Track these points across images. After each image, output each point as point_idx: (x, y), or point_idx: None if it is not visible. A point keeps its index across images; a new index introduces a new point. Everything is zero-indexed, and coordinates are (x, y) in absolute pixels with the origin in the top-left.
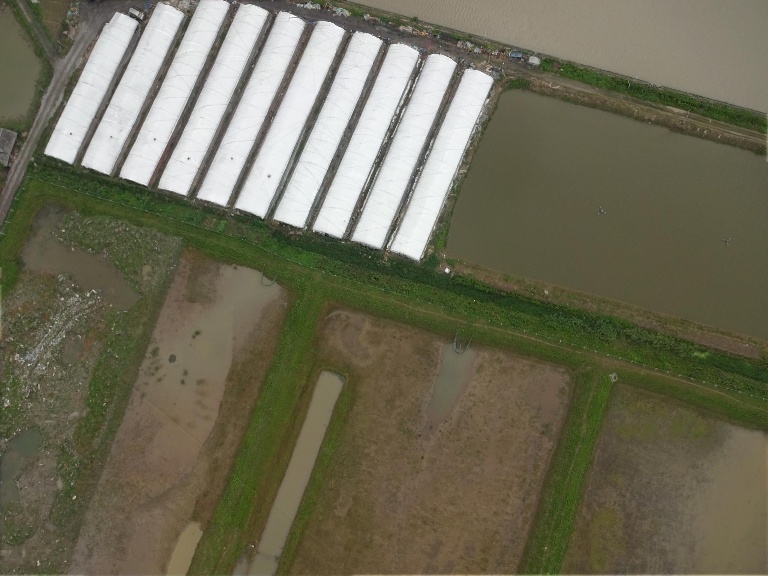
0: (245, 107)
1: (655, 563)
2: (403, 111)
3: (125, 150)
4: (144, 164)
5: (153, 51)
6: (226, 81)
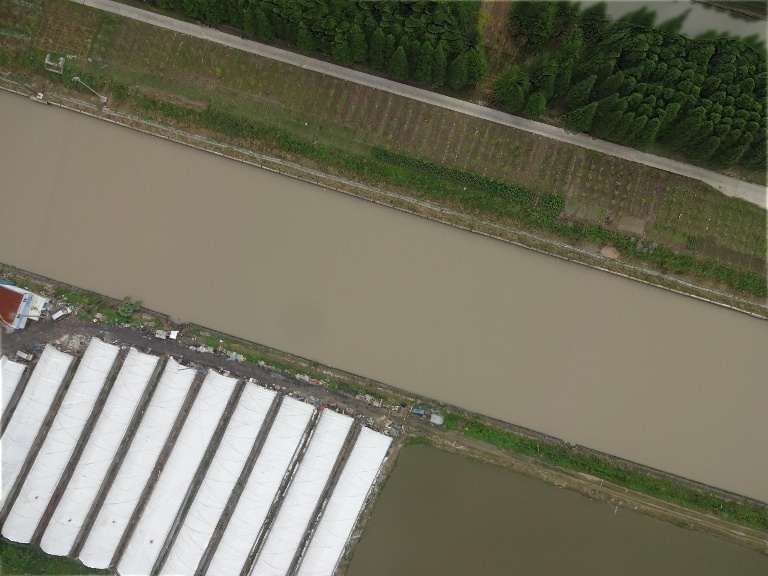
0: (129, 465)
1: None
2: (296, 467)
3: (9, 501)
4: (25, 524)
5: (38, 401)
6: (111, 436)
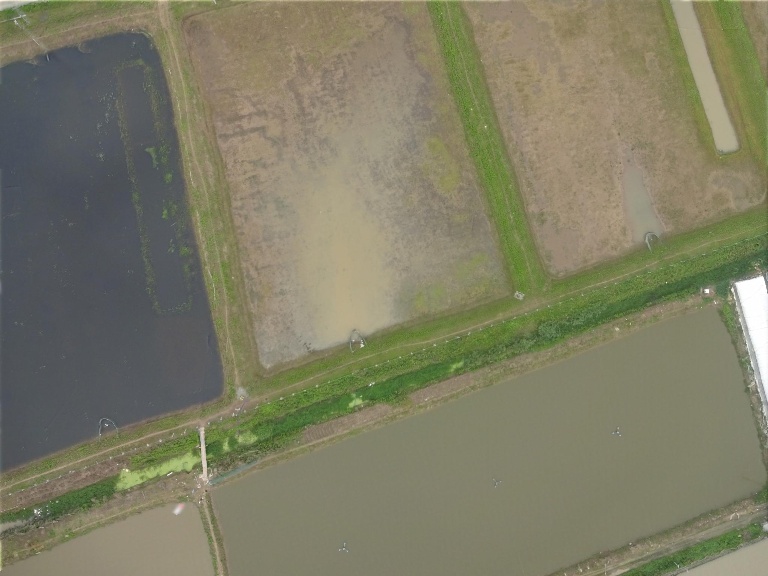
0: None
1: (390, 172)
2: None
3: None
4: None
5: None
6: None
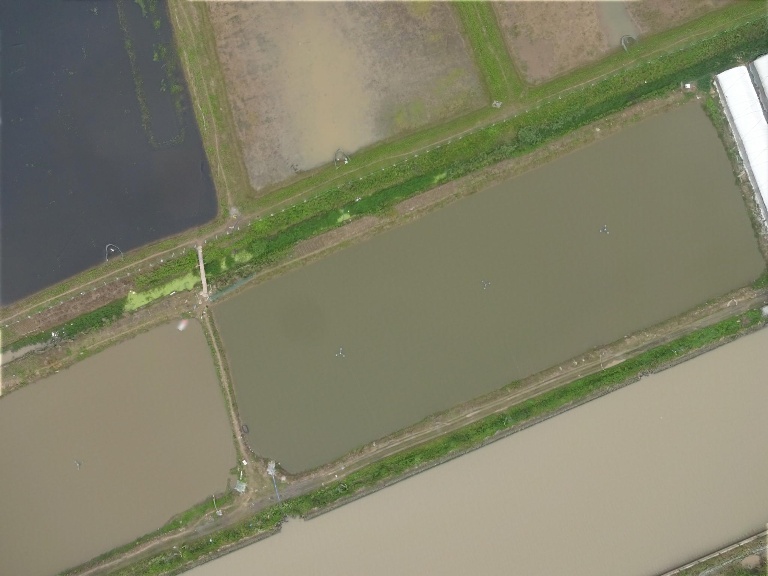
0: None
1: (364, 2)
2: None
3: None
4: None
5: None
6: None
